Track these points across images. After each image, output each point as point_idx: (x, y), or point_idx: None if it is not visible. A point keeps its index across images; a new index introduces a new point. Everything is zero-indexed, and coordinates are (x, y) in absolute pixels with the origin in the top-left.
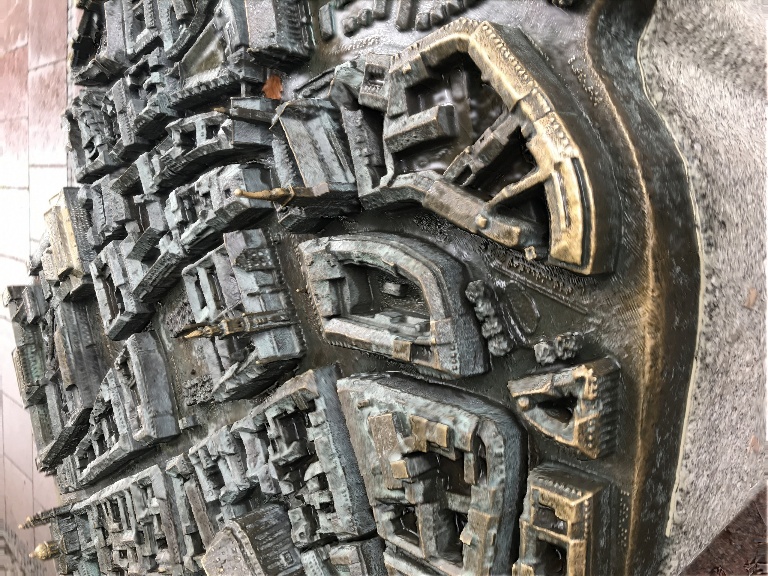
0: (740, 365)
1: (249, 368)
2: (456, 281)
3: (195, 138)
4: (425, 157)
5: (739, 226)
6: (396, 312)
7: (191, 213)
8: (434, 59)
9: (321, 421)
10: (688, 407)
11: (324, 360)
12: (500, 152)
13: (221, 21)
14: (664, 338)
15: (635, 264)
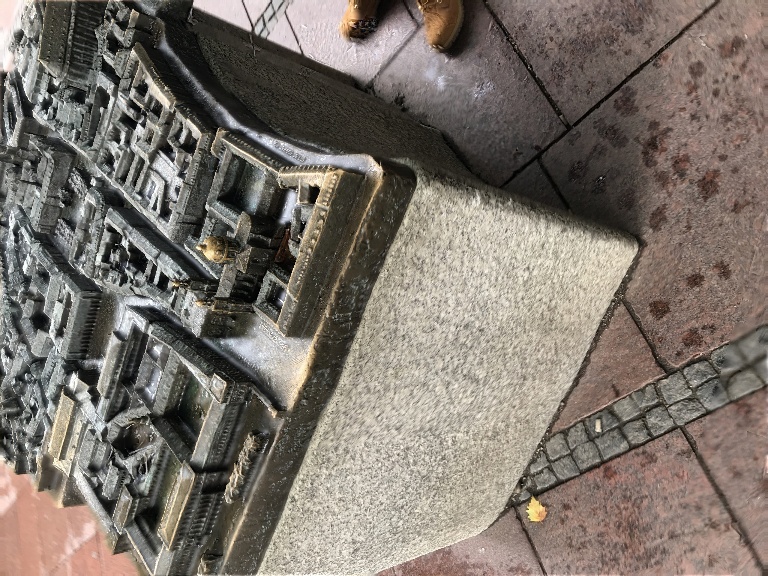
0: None
1: None
2: None
3: None
4: None
5: None
6: None
7: None
8: None
9: None
10: None
11: None
12: None
13: None
14: None
15: None
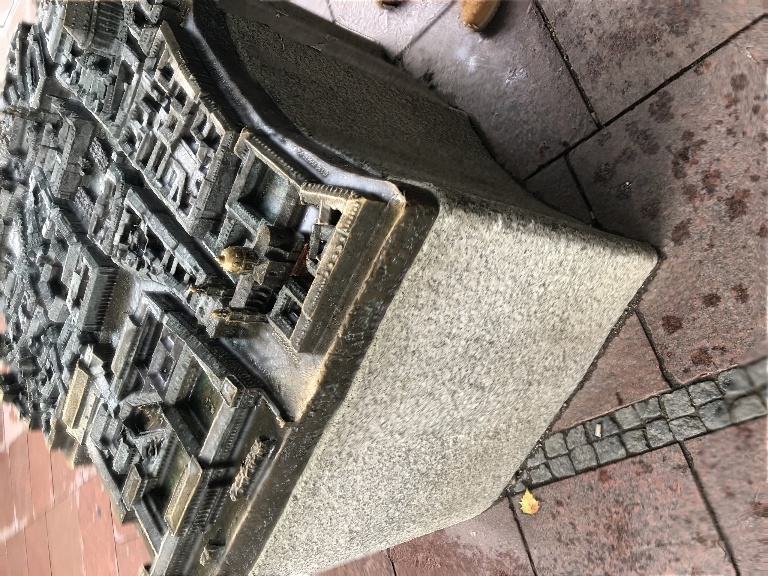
0: None
1: None
2: None
3: None
4: None
5: None
6: None
7: None
8: None
9: None
10: None
11: None
12: None
13: None
14: None
15: None
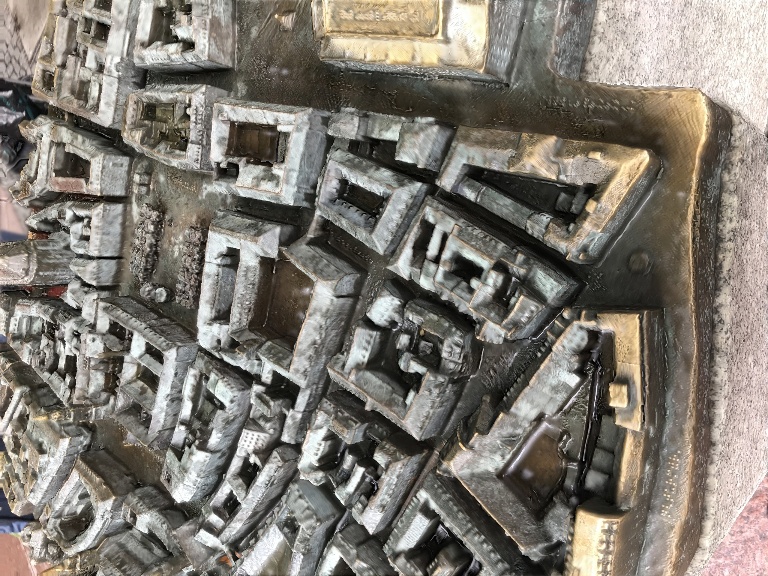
0: None
1: None
2: None
3: None
4: None
5: None
6: None
7: None
8: None
9: None
10: None
11: None
12: None
13: None
14: None
15: None
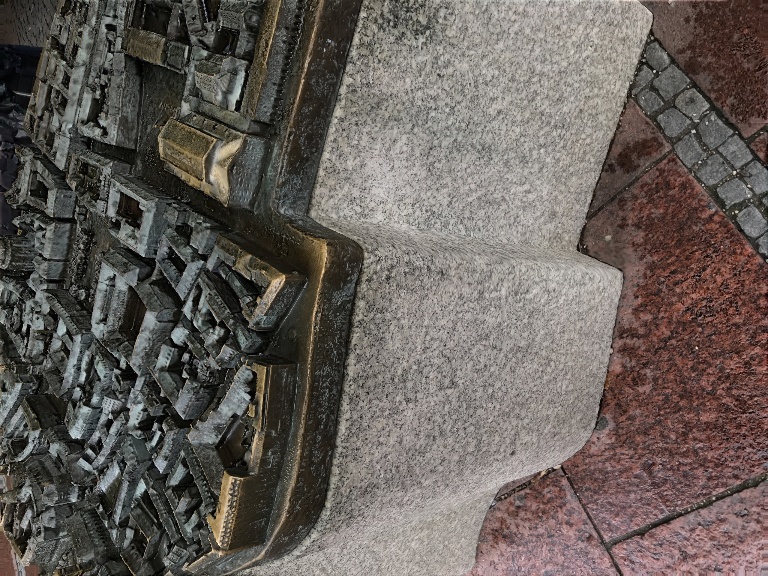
0: None
1: None
2: None
3: None
4: None
5: None
6: None
7: None
8: None
9: None
10: None
11: None
12: None
13: (110, 524)
14: None
15: None
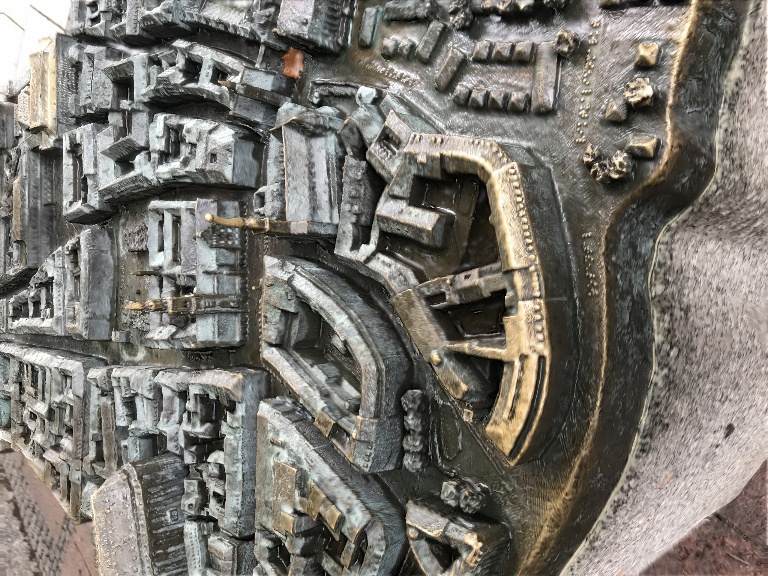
0: (631, 528)
1: (185, 339)
2: (397, 381)
3: (200, 68)
4: (411, 247)
5: (684, 420)
6: (336, 367)
7: (175, 146)
8: (452, 167)
9: (236, 426)
10: (562, 574)
11: (259, 360)
12: (479, 299)
13: None
14: (560, 533)
15: (561, 462)
